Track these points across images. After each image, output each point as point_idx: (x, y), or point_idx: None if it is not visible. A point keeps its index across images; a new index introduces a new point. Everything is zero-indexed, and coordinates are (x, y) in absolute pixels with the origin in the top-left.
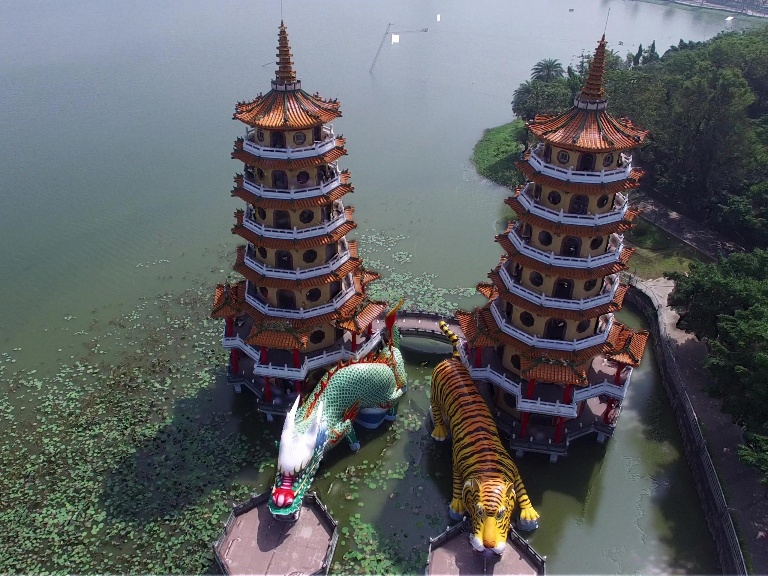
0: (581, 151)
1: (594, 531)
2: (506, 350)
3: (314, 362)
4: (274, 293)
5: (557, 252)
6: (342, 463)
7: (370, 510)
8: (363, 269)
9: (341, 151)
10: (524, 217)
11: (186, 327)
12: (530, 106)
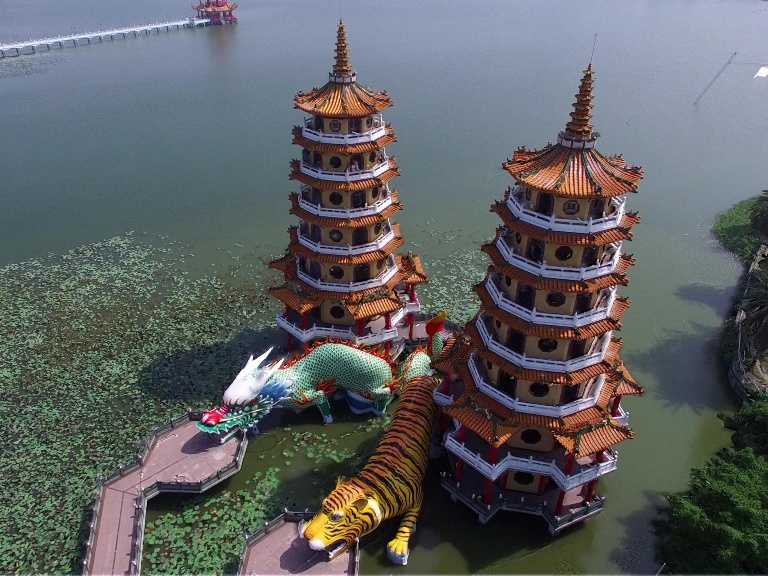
0: None
1: None
2: None
3: (322, 332)
4: (309, 260)
5: (513, 296)
6: (307, 427)
7: (290, 471)
8: (414, 269)
9: (374, 146)
10: (486, 248)
11: None
12: None
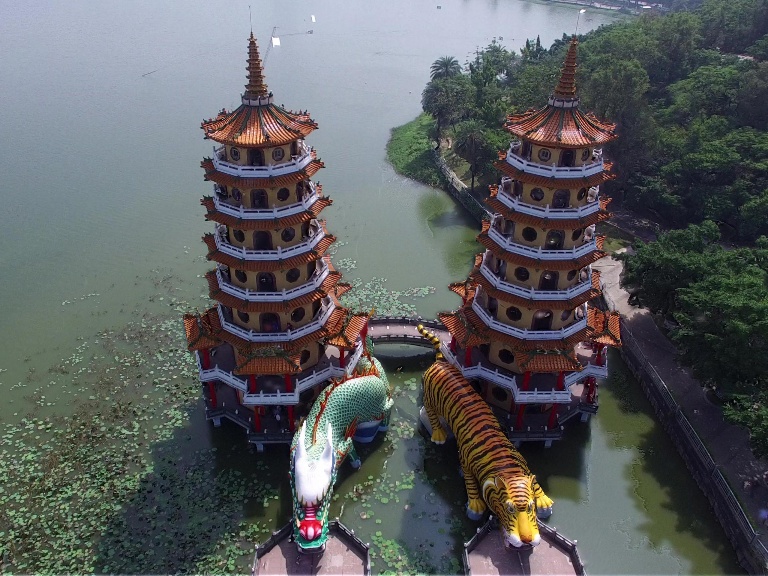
0: (564, 148)
1: (600, 507)
2: (493, 346)
3: (305, 384)
4: (256, 317)
5: (542, 246)
6: (347, 483)
7: (389, 526)
8: None
9: (319, 164)
10: (510, 216)
11: (139, 364)
12: (442, 104)
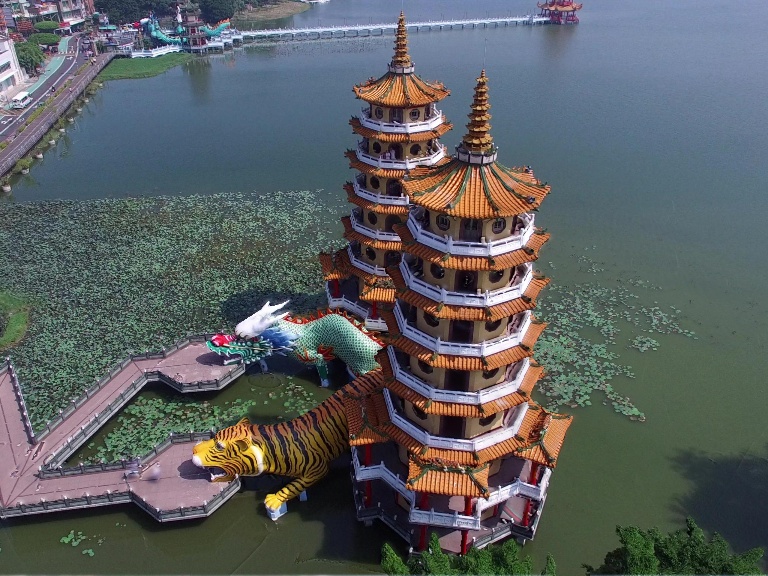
0: None
1: (291, 575)
2: None
3: (349, 304)
4: None
5: None
6: (306, 382)
7: (262, 409)
8: None
9: (406, 138)
10: None
11: None
12: None
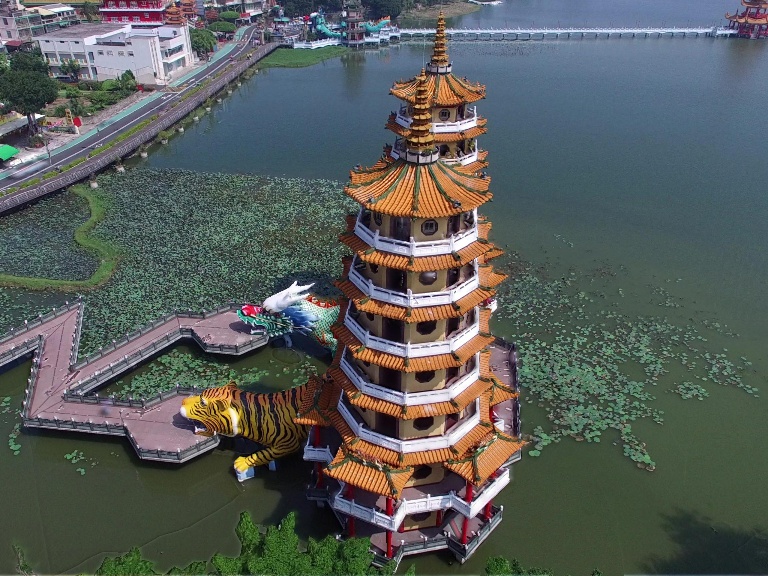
0: None
1: None
2: None
3: None
4: None
5: None
6: (321, 364)
7: (272, 380)
8: None
9: None
10: None
11: None
12: None
